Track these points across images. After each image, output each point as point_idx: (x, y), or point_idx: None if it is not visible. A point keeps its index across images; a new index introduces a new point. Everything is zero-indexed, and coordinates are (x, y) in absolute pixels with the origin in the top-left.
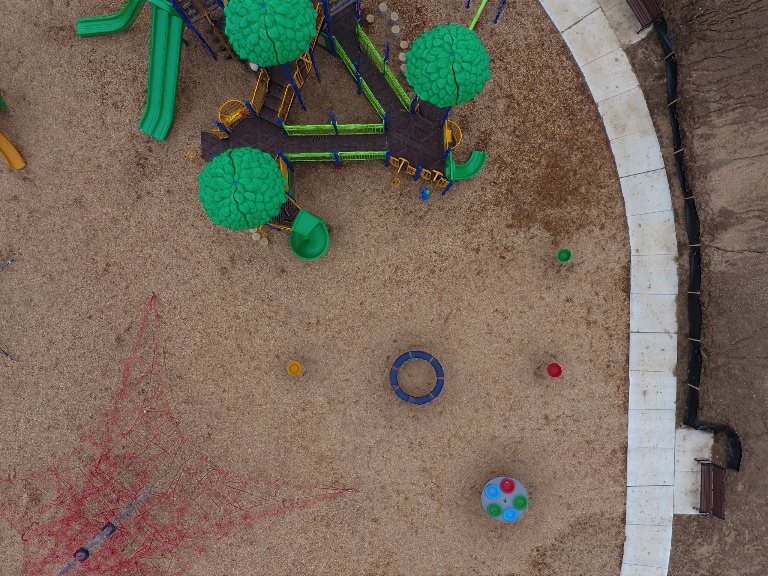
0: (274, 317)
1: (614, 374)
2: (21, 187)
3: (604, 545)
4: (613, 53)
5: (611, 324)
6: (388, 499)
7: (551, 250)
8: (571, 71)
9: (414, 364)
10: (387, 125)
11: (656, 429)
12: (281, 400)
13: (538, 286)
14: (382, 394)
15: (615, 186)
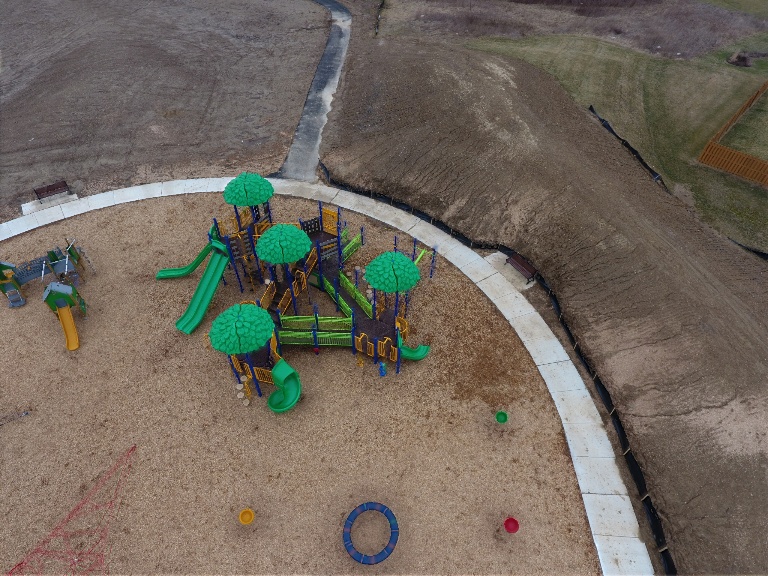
0: (239, 469)
1: (578, 539)
2: (66, 362)
3: None
4: (513, 294)
5: (561, 485)
6: None
7: (492, 418)
8: (486, 302)
9: (369, 522)
10: (355, 325)
11: None
12: (224, 559)
13: (485, 448)
14: (334, 556)
15: (535, 371)
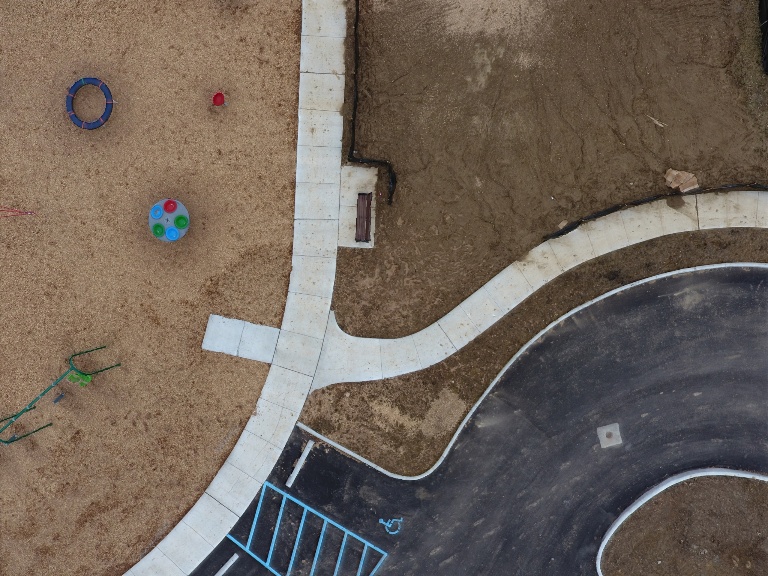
0: None
1: (285, 112)
2: None
3: (271, 274)
4: None
5: (283, 64)
6: (66, 223)
7: None
8: None
9: (94, 96)
10: None
11: (323, 165)
12: None
13: (213, 25)
14: (62, 123)
15: None
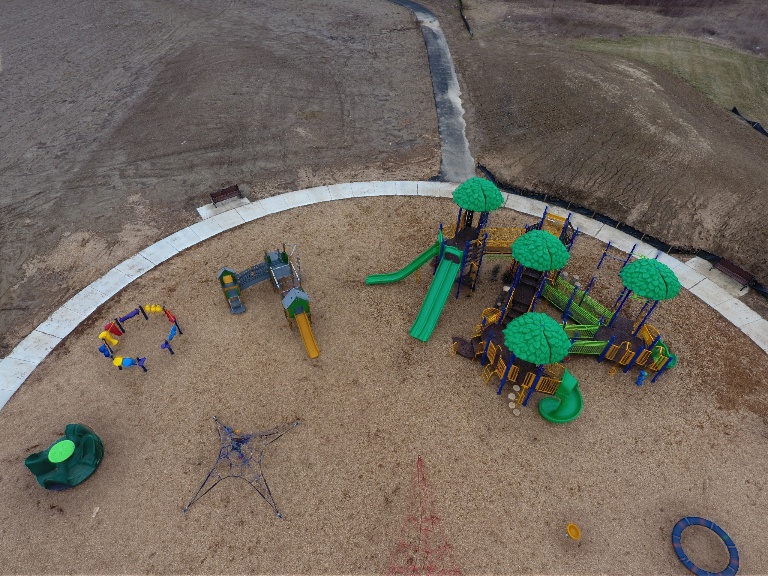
0: (536, 482)
1: None
2: (311, 371)
3: None
4: (731, 300)
5: None
6: None
7: (767, 429)
8: (708, 309)
9: (692, 537)
10: None
11: None
12: None
13: None
14: (672, 572)
15: None
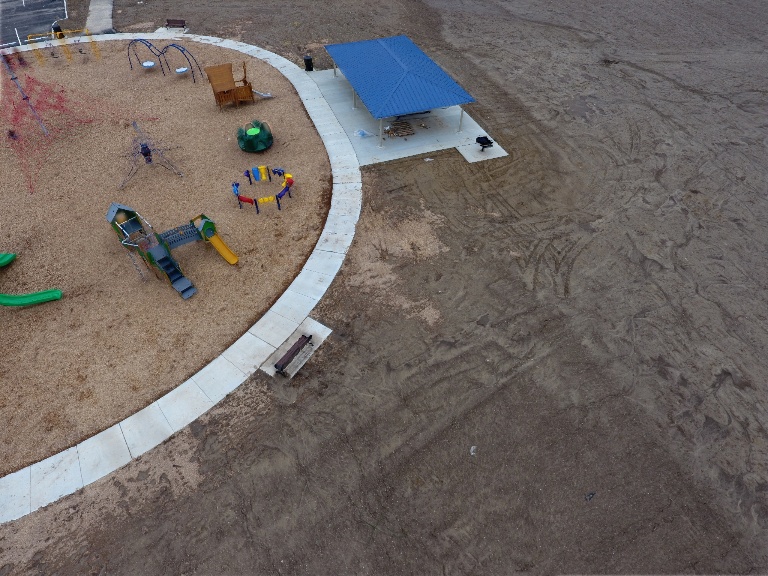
0: None
1: None
2: None
3: None
4: None
5: None
6: None
7: None
8: None
9: None
10: None
11: None
12: None
13: None
14: None
15: None
